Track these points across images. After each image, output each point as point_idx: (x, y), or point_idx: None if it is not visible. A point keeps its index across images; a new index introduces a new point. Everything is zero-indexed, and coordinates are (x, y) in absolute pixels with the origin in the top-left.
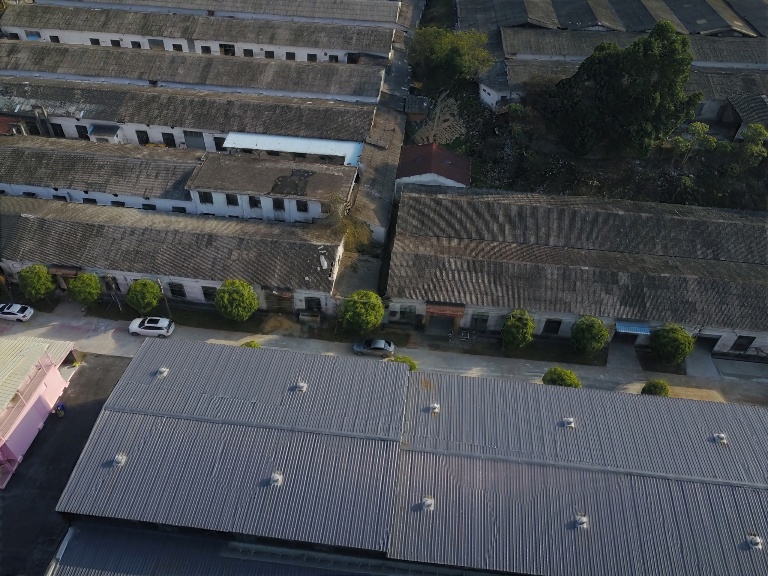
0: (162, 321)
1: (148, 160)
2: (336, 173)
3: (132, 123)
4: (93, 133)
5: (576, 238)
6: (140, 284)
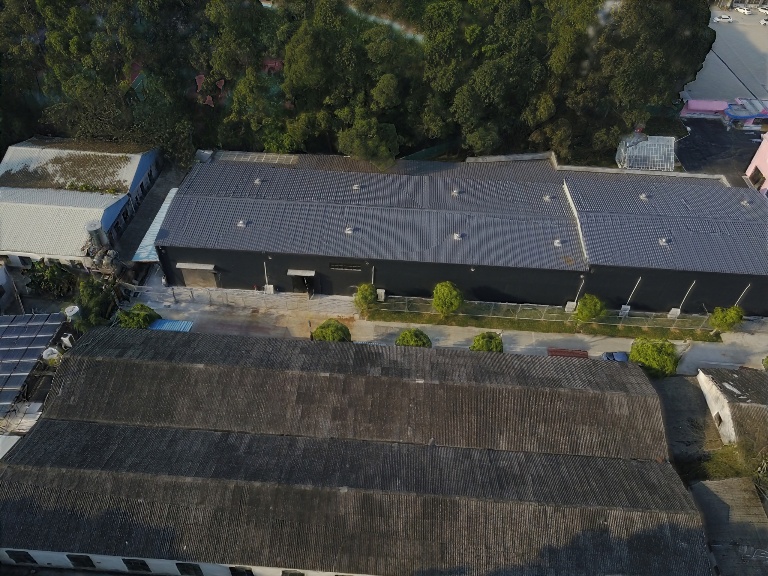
0: None
1: None
2: None
3: None
4: None
5: (416, 456)
6: None
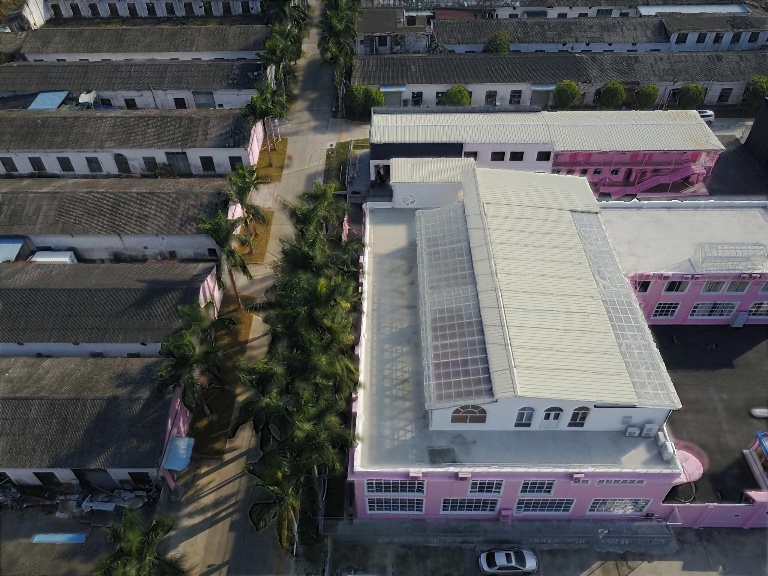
0: (709, 111)
1: (622, 19)
2: (762, 16)
3: (560, 7)
4: (531, 17)
5: None
6: (693, 86)
